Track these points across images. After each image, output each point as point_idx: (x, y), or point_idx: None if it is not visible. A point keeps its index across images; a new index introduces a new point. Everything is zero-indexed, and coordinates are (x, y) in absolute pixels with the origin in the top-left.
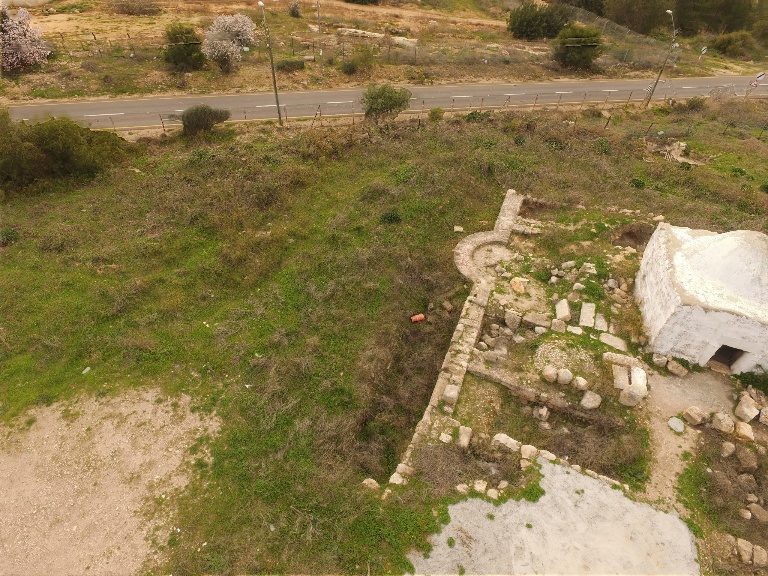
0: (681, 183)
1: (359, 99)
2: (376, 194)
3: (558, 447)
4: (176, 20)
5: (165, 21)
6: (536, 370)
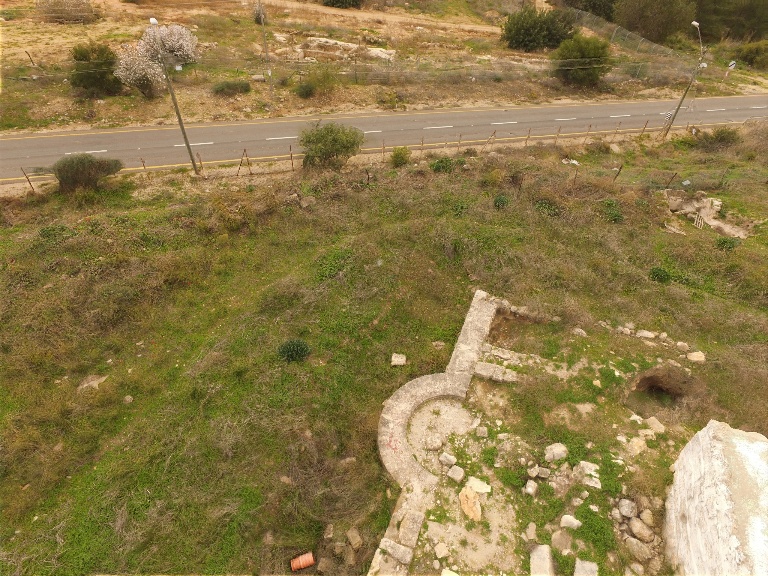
0: (721, 273)
1: (299, 139)
2: (284, 301)
3: None
4: (84, 35)
5: (99, 31)
6: None
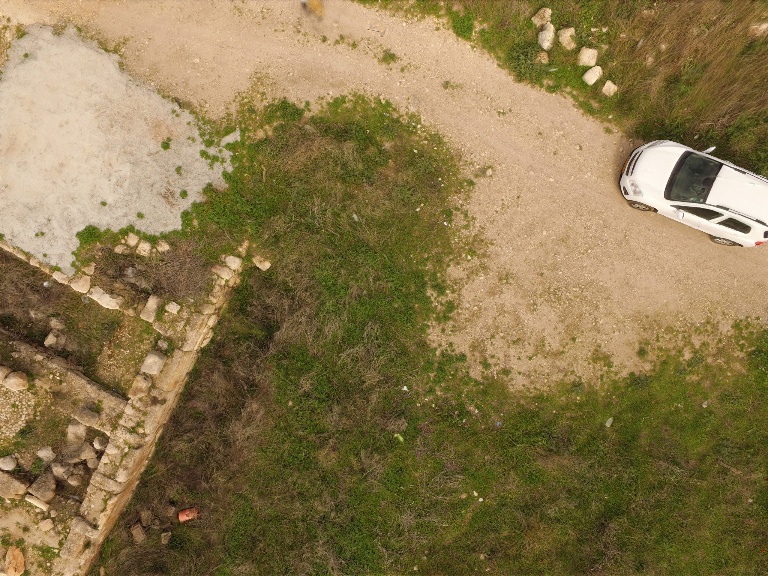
0: None
1: None
2: None
3: (50, 296)
4: None
5: None
6: (35, 393)
